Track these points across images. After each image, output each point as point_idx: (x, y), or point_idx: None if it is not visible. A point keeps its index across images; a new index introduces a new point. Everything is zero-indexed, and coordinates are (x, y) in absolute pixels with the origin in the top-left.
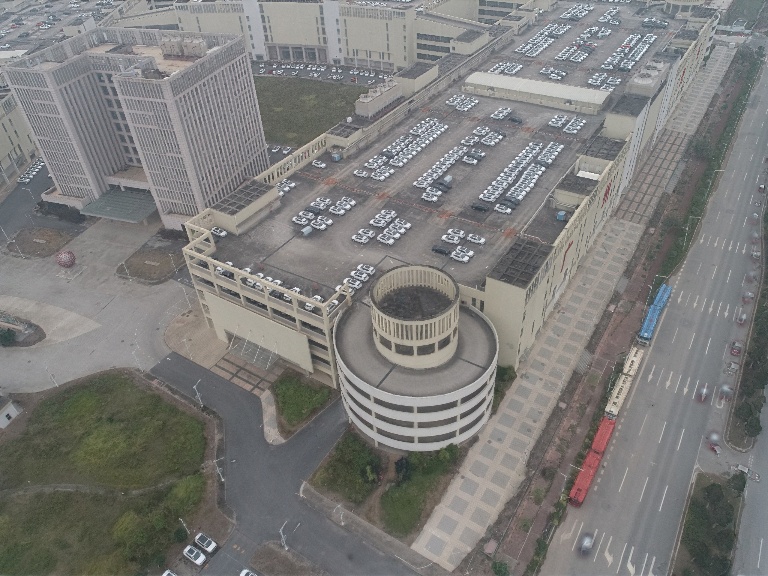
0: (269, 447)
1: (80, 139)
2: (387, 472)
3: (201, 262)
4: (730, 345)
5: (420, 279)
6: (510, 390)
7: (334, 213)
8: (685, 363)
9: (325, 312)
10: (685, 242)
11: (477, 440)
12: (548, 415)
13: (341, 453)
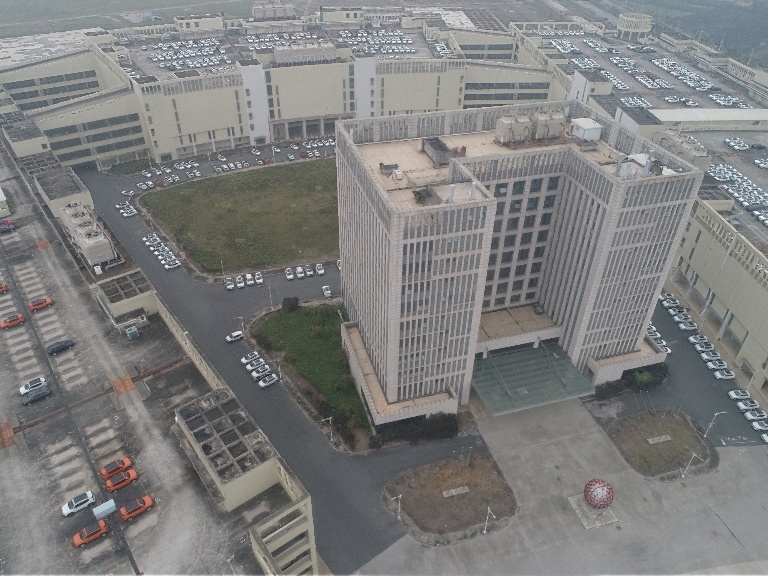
0: None
1: None
2: None
3: None
4: None
5: None
6: None
7: None
8: None
9: None
10: None
11: None
12: None
13: None
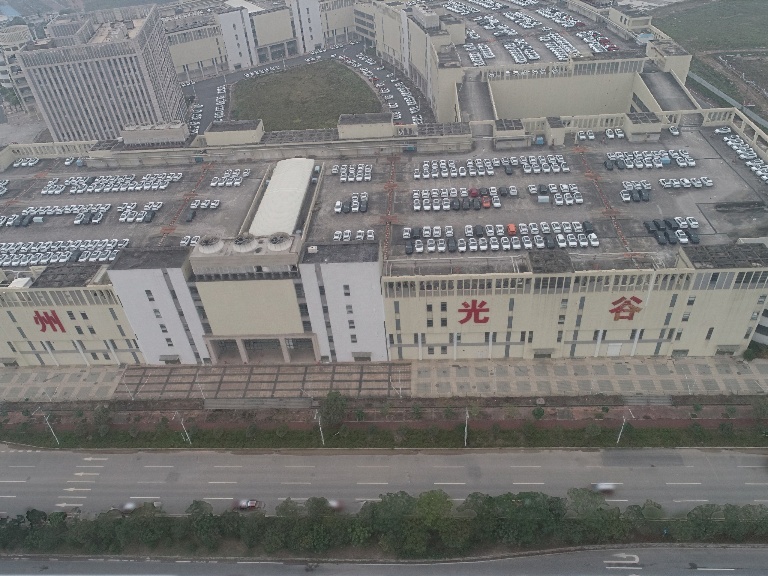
0: None
1: None
2: None
3: None
4: None
5: None
6: None
7: None
8: None
9: None
10: (75, 441)
11: None
12: None
13: None
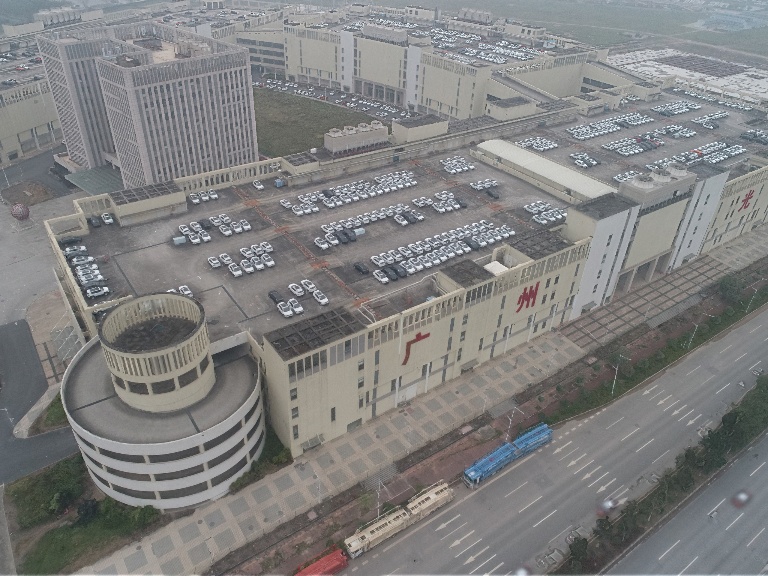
0: (9, 437)
1: (82, 112)
2: (77, 508)
3: (61, 239)
4: (574, 528)
5: (191, 314)
6: (272, 475)
7: (222, 232)
8: (498, 527)
9: (89, 317)
10: (621, 386)
11: (190, 514)
12: (286, 520)
13: (55, 470)
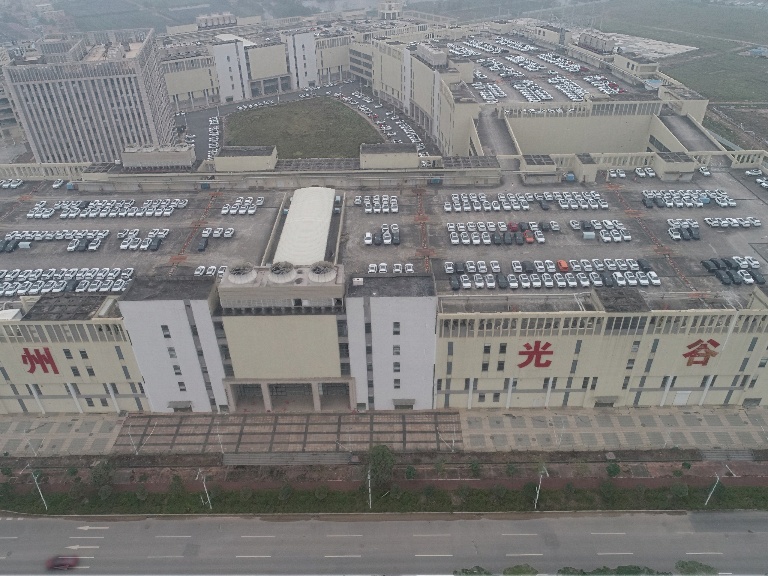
0: None
1: None
2: None
3: None
4: None
5: None
6: None
7: None
8: None
9: None
10: (68, 505)
11: None
12: None
13: None
